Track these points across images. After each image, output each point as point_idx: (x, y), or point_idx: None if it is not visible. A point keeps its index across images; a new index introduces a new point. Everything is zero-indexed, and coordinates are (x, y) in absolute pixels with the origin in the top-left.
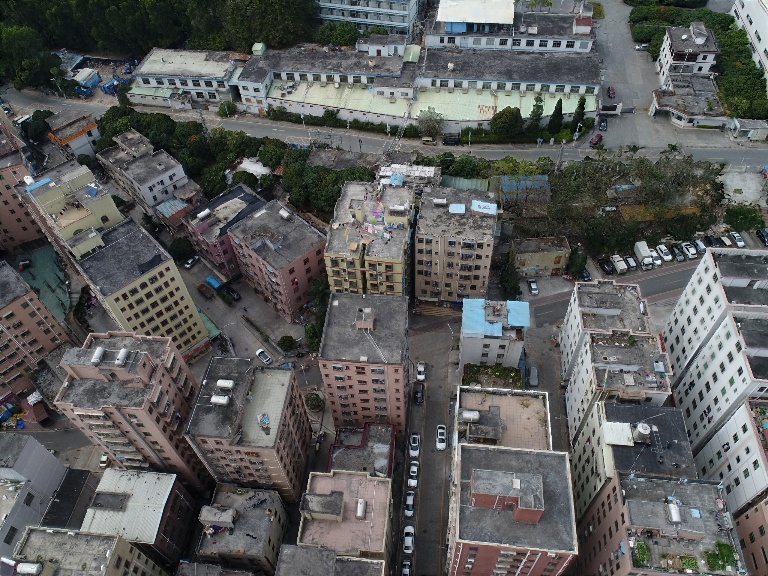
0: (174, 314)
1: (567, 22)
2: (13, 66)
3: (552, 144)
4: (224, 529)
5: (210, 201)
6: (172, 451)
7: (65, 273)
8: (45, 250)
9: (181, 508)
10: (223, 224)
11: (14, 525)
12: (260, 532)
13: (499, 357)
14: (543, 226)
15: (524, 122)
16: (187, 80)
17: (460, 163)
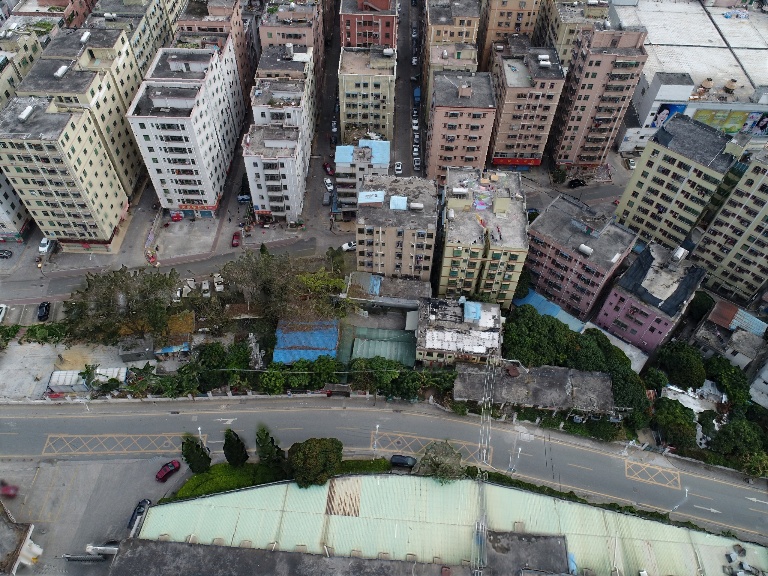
0: None
1: None
2: None
3: None
4: None
5: None
6: None
7: None
8: None
9: None
10: (655, 264)
11: None
12: None
13: None
14: None
15: (285, 464)
16: None
17: (391, 362)
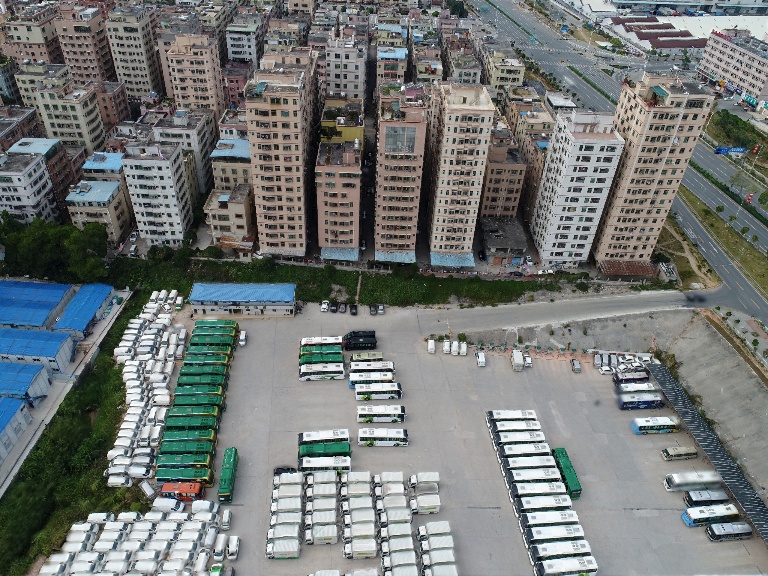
0: None
1: None
2: None
3: None
4: None
5: None
6: None
7: None
8: None
9: None
10: None
11: None
12: None
13: None
14: None
15: None
16: None
17: (145, 2)
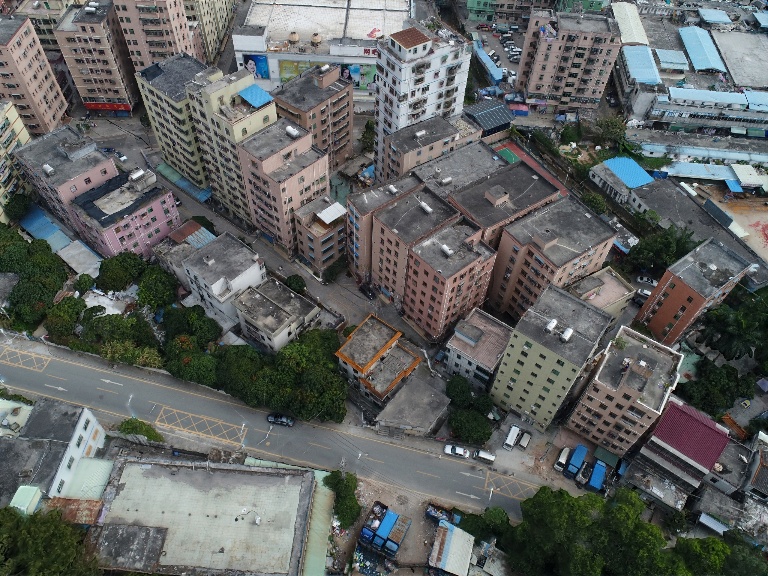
0: None
1: None
2: None
3: None
4: None
5: (140, 210)
6: None
7: None
8: None
9: None
10: (125, 186)
11: None
12: None
13: None
14: None
15: None
16: None
17: None
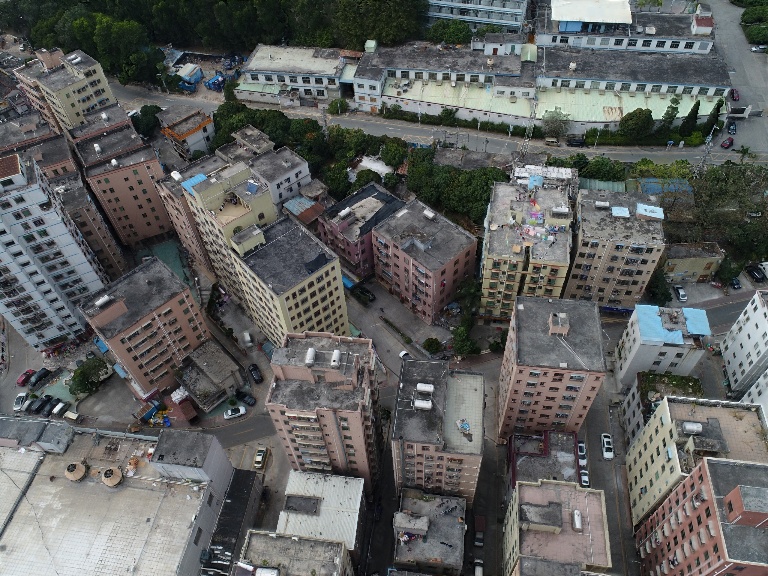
0: (328, 314)
1: (683, 22)
2: (119, 61)
3: (681, 147)
4: (417, 536)
5: (344, 199)
6: (363, 455)
7: (193, 269)
8: (165, 246)
9: (362, 513)
10: (362, 223)
11: (200, 526)
12: (454, 540)
13: (671, 366)
14: (697, 231)
15: (654, 124)
16: (297, 77)
17: (596, 165)
